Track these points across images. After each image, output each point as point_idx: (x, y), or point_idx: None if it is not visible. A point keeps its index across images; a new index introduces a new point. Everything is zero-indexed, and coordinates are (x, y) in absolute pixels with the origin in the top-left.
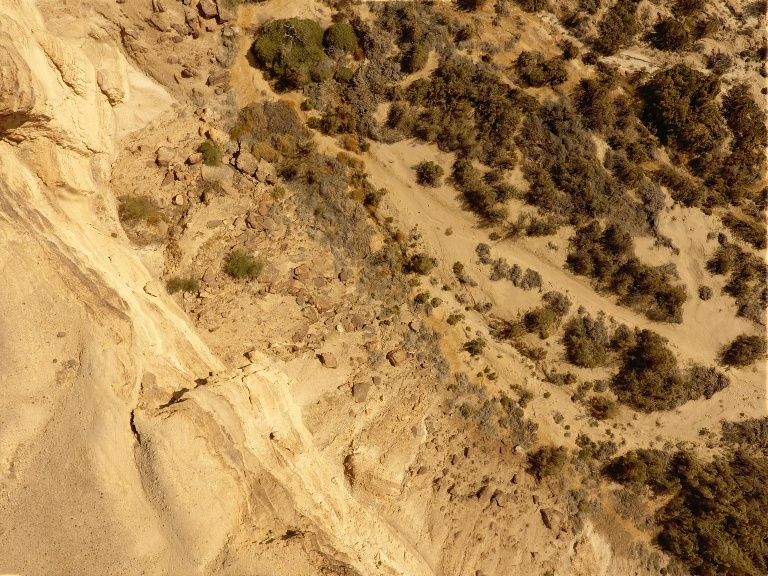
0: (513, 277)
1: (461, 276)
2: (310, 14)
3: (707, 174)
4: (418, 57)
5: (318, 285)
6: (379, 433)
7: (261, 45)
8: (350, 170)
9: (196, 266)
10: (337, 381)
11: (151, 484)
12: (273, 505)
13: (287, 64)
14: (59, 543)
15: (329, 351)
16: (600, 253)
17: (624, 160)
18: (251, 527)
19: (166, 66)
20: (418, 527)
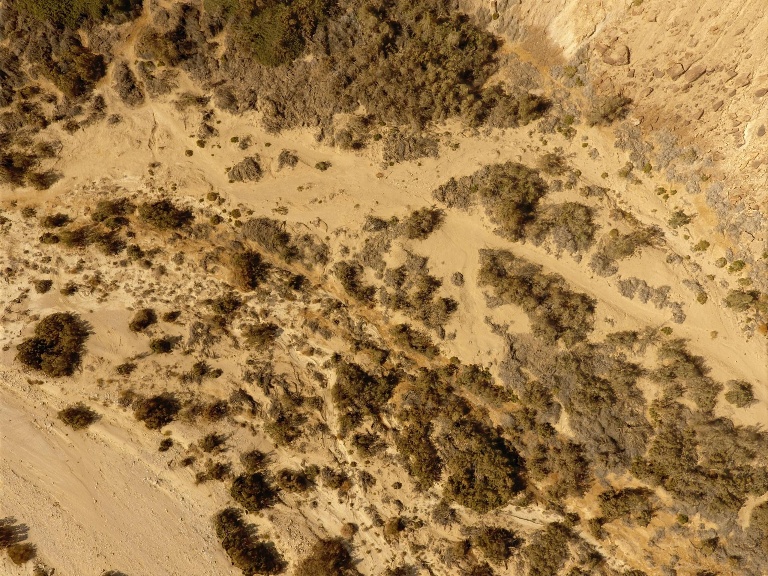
0: (647, 290)
1: (700, 290)
2: None
3: (452, 399)
4: None
5: None
6: None
7: None
8: None
9: None
10: None
11: None
12: None
13: None
14: None
15: None
16: (567, 316)
17: (543, 412)
18: None
19: None
20: None
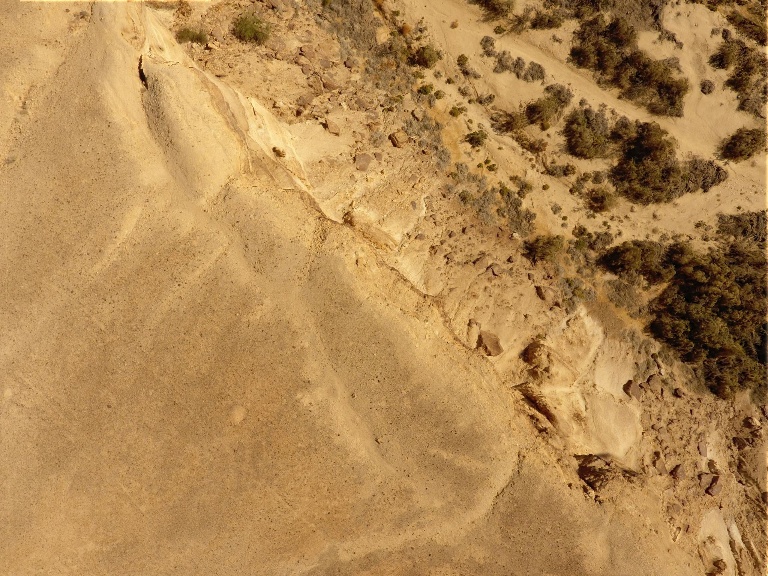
0: (516, 69)
1: (465, 68)
2: None
3: None
4: None
5: (324, 65)
6: (379, 200)
7: None
8: None
9: (205, 22)
10: (339, 148)
11: (157, 121)
12: (274, 176)
13: None
14: (68, 168)
15: (332, 121)
16: (604, 43)
17: None
18: (252, 178)
19: None
20: (414, 279)
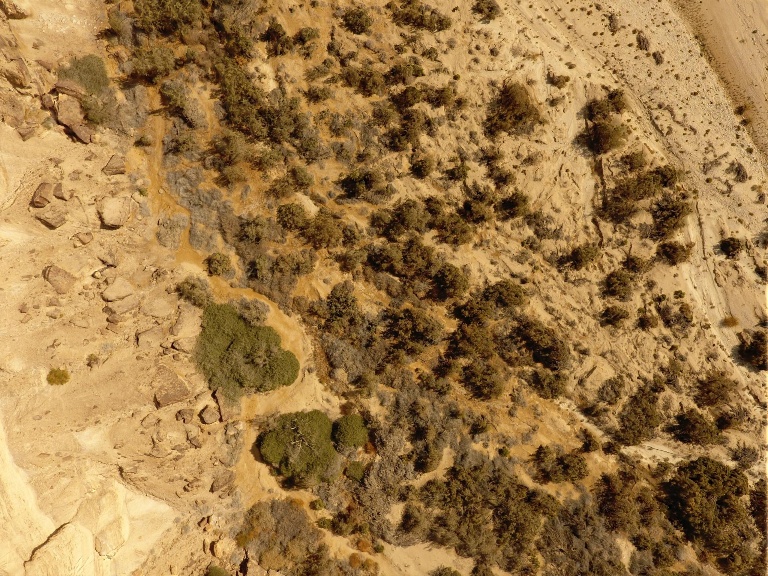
0: None
1: None
2: (317, 404)
3: None
4: (433, 464)
5: None
6: None
7: (267, 450)
8: (364, 574)
9: None
10: None
11: None
12: None
13: (295, 470)
14: None
15: None
16: None
17: (650, 567)
18: None
19: (167, 486)
20: None
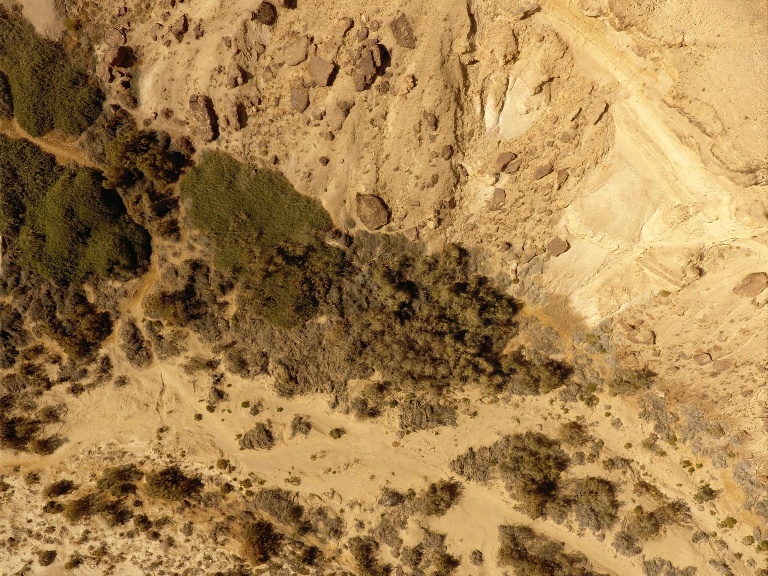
0: (673, 571)
1: (727, 571)
2: None
3: None
4: None
5: None
6: None
7: None
8: None
9: None
10: None
11: None
12: None
13: None
14: None
15: None
16: None
17: None
18: None
19: None
20: None
